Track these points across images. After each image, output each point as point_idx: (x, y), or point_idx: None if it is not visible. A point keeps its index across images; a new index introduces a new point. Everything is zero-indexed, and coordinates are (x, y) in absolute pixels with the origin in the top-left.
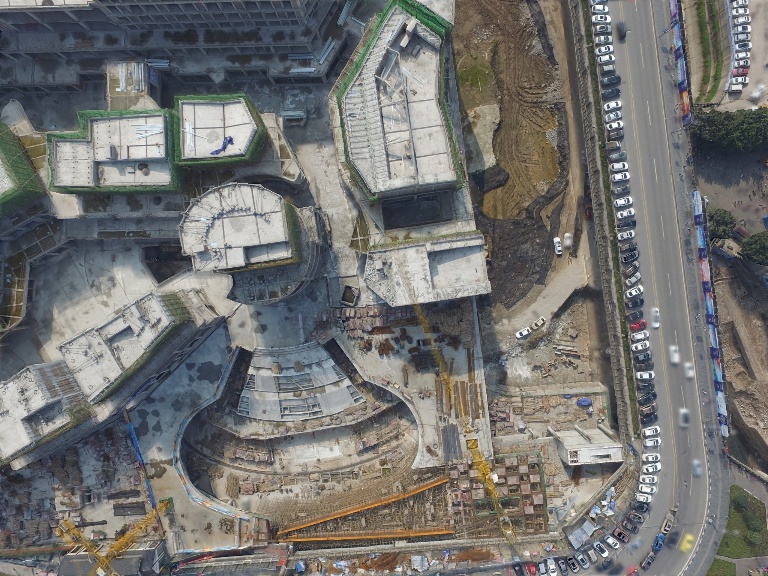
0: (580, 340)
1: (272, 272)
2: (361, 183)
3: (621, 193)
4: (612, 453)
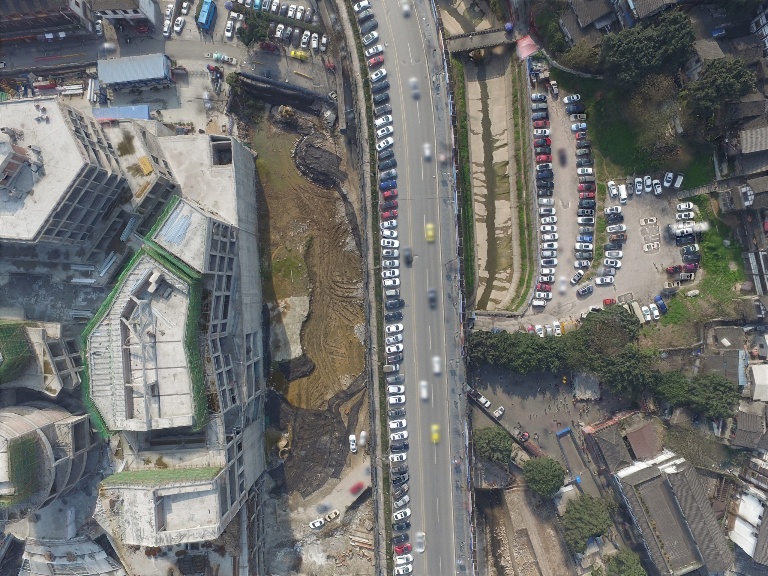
0: None
1: None
2: (100, 420)
3: (395, 416)
4: None
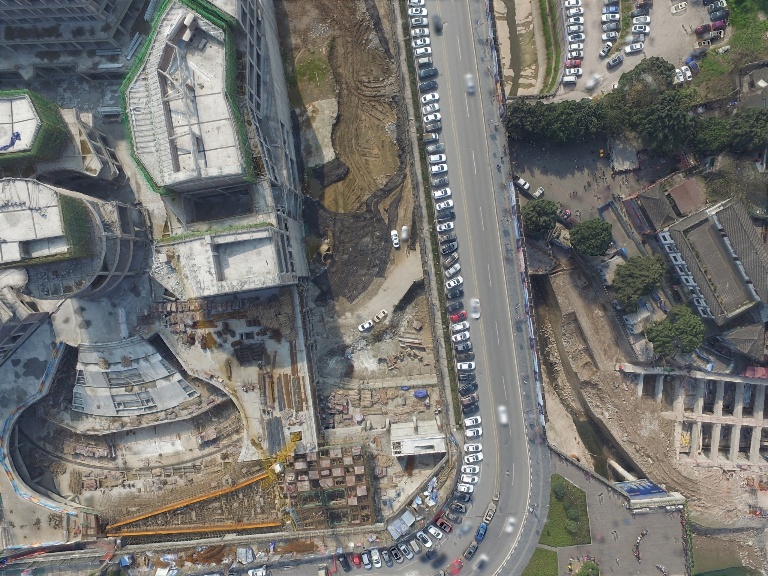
0: (425, 332)
1: (66, 267)
2: (147, 177)
3: (439, 185)
4: (435, 444)
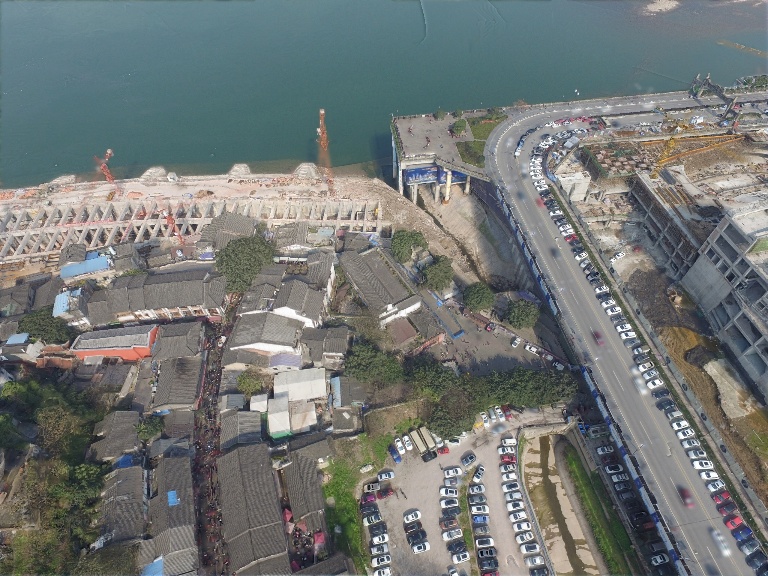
0: None
1: None
2: None
3: None
4: (562, 178)
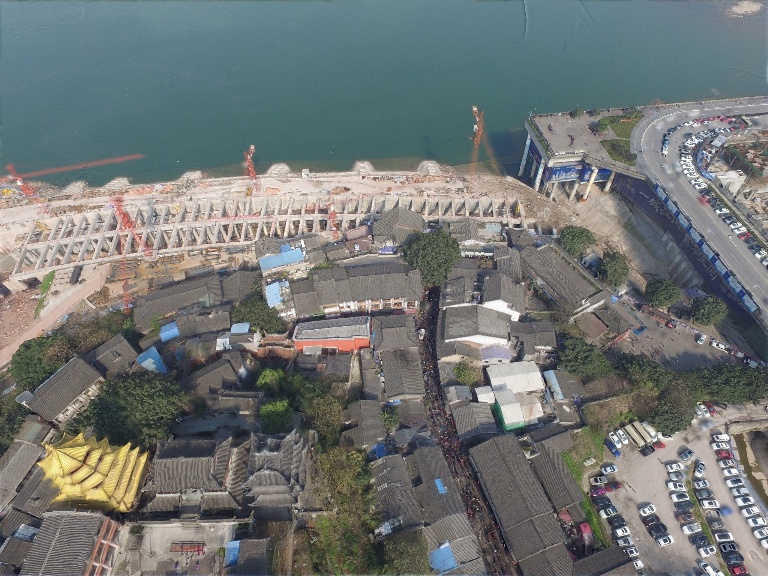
0: None
1: None
2: None
3: None
4: None
